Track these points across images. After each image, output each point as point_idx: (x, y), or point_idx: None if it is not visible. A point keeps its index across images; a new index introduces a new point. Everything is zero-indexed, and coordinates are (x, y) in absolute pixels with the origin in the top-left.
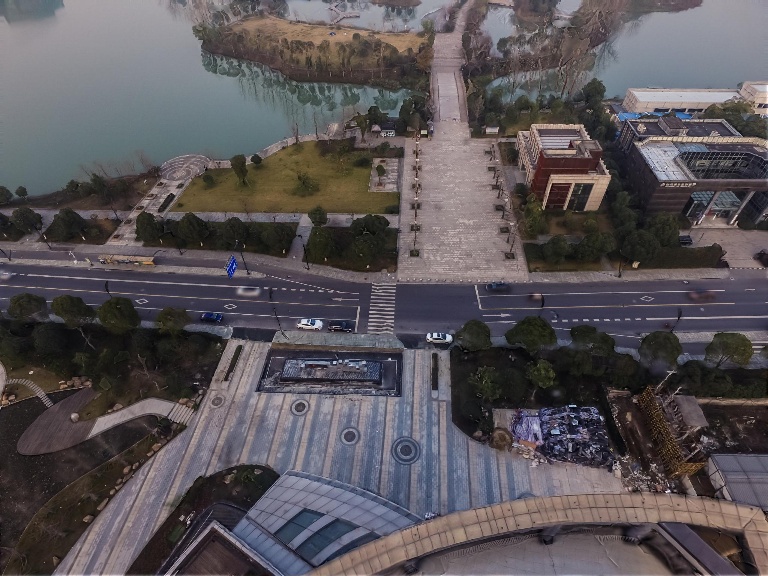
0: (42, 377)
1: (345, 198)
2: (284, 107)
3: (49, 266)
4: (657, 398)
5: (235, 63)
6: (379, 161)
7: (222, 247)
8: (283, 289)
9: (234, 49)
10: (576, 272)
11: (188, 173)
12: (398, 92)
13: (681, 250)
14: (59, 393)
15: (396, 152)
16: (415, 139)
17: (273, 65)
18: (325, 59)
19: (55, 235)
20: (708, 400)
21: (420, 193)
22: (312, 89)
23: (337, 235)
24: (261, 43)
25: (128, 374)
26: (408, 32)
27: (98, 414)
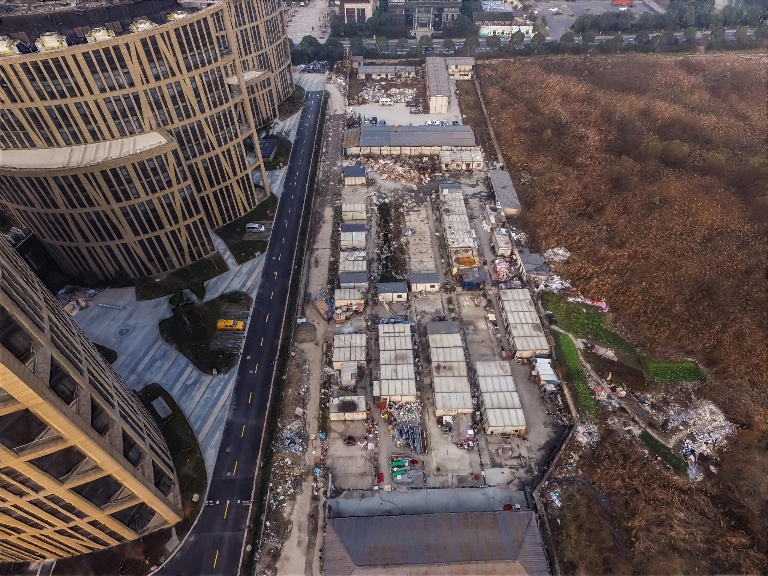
0: None
1: None
2: None
3: None
4: (345, 52)
5: None
6: None
7: None
8: None
9: None
10: (348, 41)
11: None
12: None
13: (390, 27)
14: None
15: None
16: (297, 7)
17: None
18: None
19: None
20: (371, 60)
21: (290, 23)
22: None
23: None
24: None
25: None
26: None
27: None
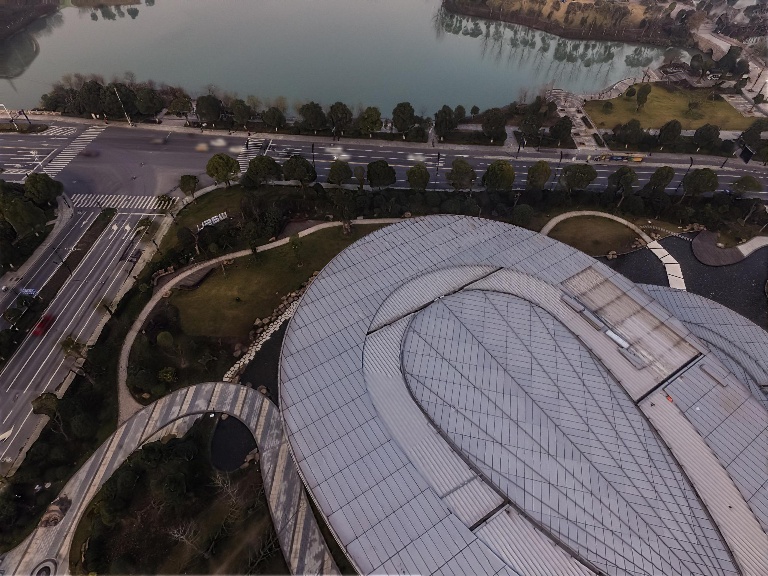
0: (662, 225)
1: (733, 121)
2: (534, 64)
3: (553, 162)
4: None
5: (481, 24)
6: (728, 96)
7: (683, 150)
8: (761, 177)
9: (492, 11)
10: None
11: (572, 103)
12: (651, 51)
13: None
14: (685, 234)
15: (737, 90)
16: None
17: (536, 25)
18: (602, 19)
19: (532, 142)
20: None
21: None
22: (575, 47)
23: (762, 144)
24: (527, 5)
25: (724, 223)
26: (629, 2)
27: (734, 244)
